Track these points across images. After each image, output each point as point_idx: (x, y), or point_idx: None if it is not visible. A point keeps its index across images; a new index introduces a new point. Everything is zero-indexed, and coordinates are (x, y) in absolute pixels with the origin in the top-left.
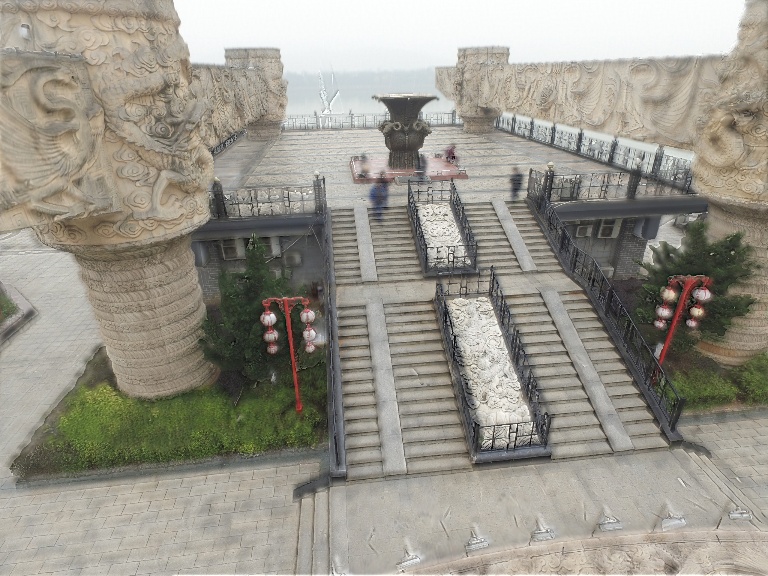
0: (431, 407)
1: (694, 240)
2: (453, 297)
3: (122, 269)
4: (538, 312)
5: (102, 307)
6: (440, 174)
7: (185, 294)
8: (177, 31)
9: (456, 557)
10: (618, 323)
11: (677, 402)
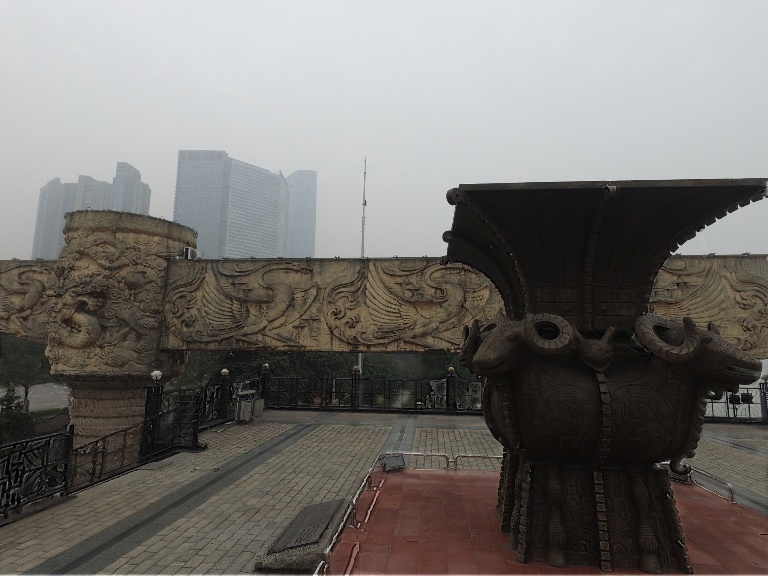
0: None
1: None
2: None
3: None
4: None
5: None
6: None
7: None
8: None
9: None
10: None
11: None
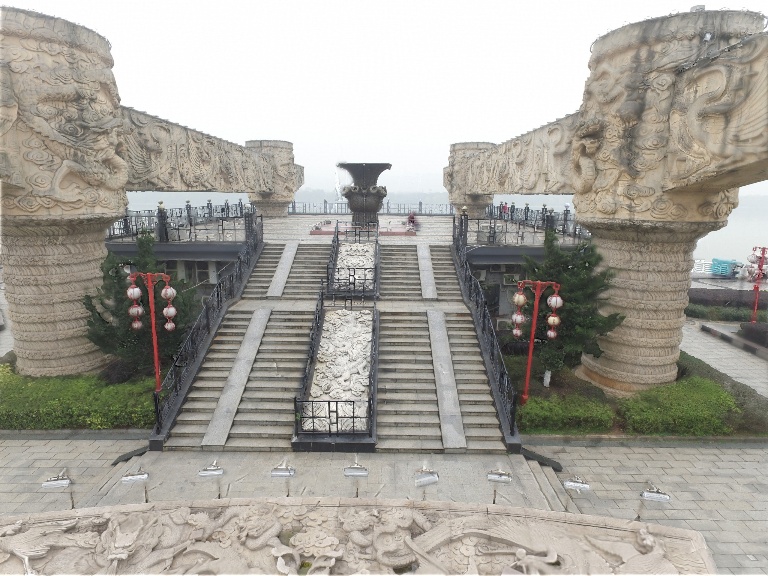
0: (276, 394)
1: (550, 252)
2: (338, 308)
3: (25, 244)
4: (418, 327)
5: (7, 280)
6: (390, 231)
7: (84, 278)
8: (108, 67)
9: None
10: (488, 337)
11: (512, 400)
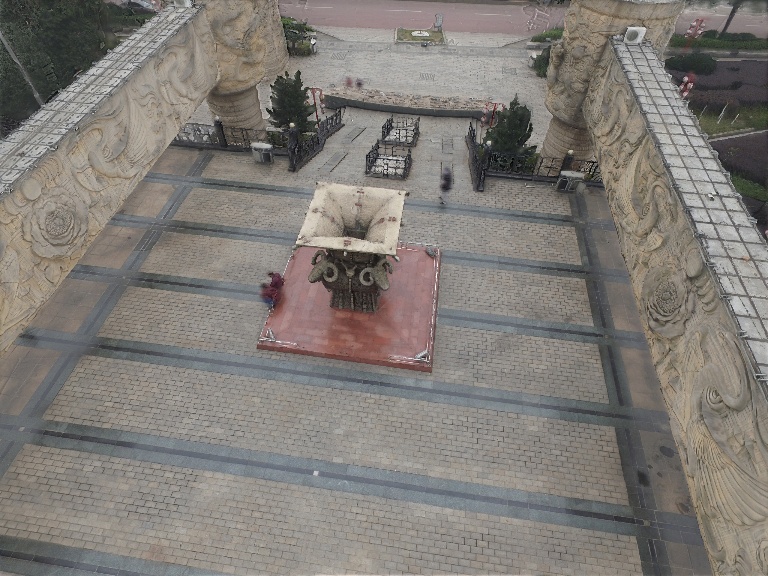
0: None
1: None
2: None
3: None
4: None
5: None
6: None
7: None
8: (577, 6)
9: (435, 119)
10: None
11: None
